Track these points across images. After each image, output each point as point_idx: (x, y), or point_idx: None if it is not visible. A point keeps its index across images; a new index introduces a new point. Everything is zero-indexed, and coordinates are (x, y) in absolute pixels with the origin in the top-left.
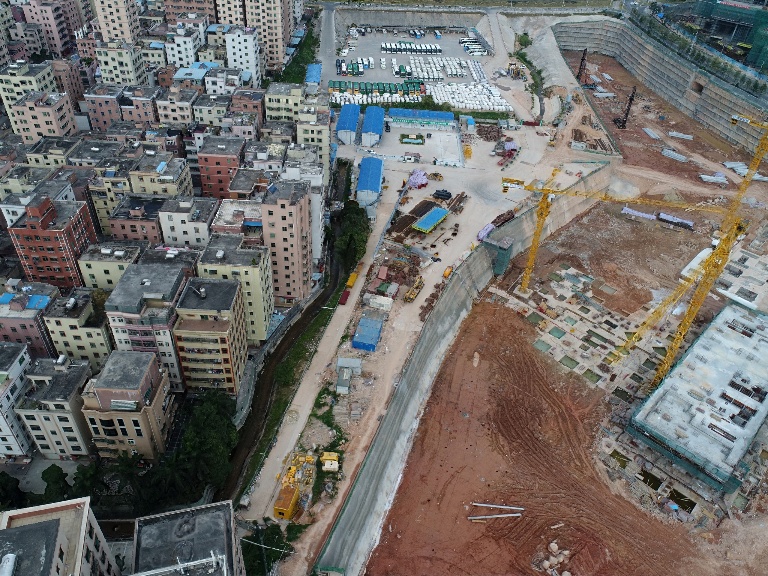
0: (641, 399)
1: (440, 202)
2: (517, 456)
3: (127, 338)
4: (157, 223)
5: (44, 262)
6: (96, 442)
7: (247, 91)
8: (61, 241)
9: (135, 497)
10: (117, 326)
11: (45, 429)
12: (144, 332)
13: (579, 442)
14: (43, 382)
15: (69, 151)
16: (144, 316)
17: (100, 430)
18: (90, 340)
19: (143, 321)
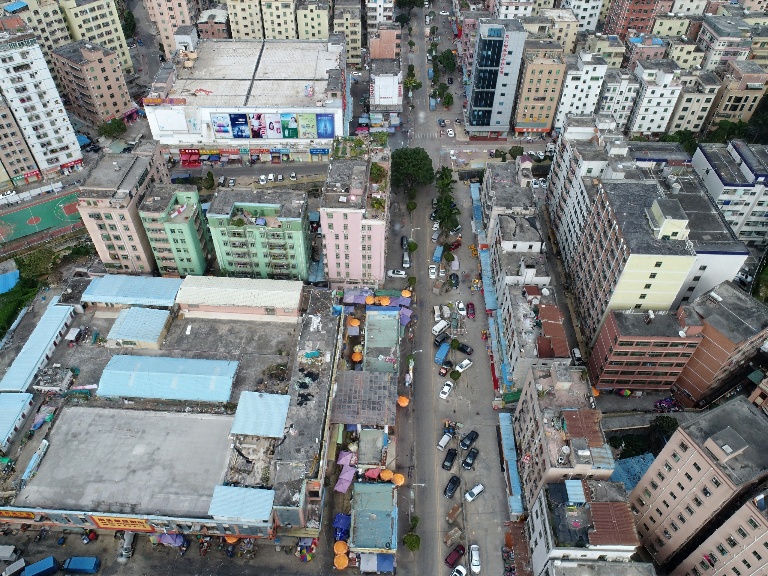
0: None
1: None
2: None
3: (718, 59)
4: (672, 3)
5: (635, 22)
6: (718, 118)
7: None
8: (656, 4)
9: (763, 139)
10: (719, 49)
11: (690, 110)
12: (734, 53)
13: None
14: (685, 83)
15: None
16: (741, 40)
17: (728, 107)
18: (692, 63)
19: (739, 44)
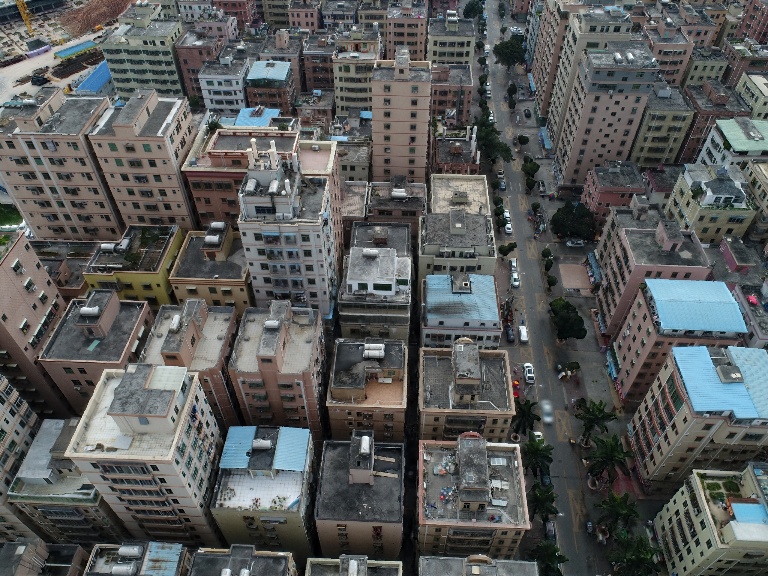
0: (39, 16)
1: (49, 77)
2: (126, 2)
3: None
4: None
5: None
6: None
7: (199, 47)
8: None
9: None
10: None
11: None
12: None
13: (91, 7)
14: None
15: (361, 2)
16: None
17: None
18: None
19: None
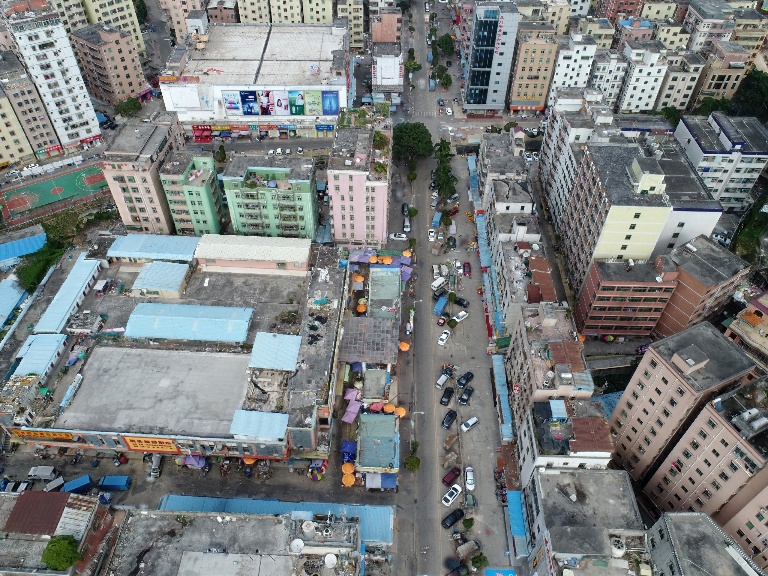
0: None
1: None
2: None
3: (703, 41)
4: None
5: (624, 6)
6: (703, 96)
7: None
8: None
9: None
10: (703, 31)
11: (676, 88)
12: (718, 35)
13: None
14: (671, 62)
15: None
16: (724, 22)
17: (712, 85)
18: (678, 44)
19: (723, 26)
